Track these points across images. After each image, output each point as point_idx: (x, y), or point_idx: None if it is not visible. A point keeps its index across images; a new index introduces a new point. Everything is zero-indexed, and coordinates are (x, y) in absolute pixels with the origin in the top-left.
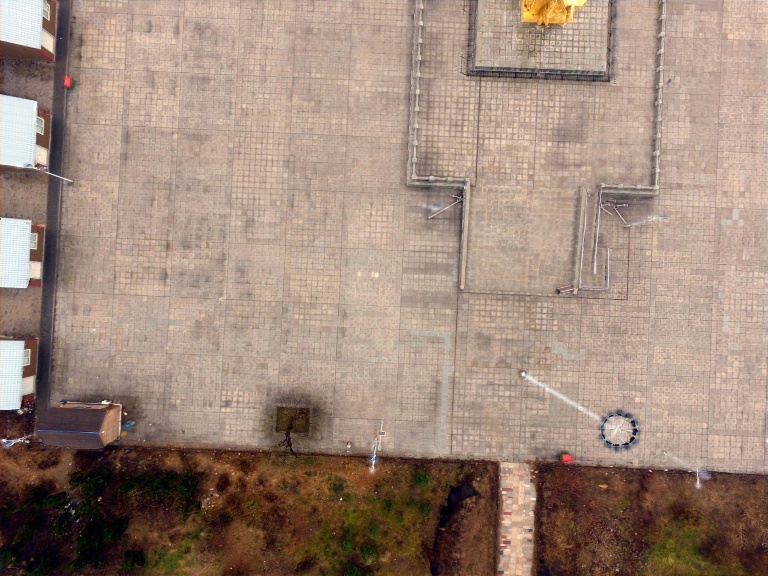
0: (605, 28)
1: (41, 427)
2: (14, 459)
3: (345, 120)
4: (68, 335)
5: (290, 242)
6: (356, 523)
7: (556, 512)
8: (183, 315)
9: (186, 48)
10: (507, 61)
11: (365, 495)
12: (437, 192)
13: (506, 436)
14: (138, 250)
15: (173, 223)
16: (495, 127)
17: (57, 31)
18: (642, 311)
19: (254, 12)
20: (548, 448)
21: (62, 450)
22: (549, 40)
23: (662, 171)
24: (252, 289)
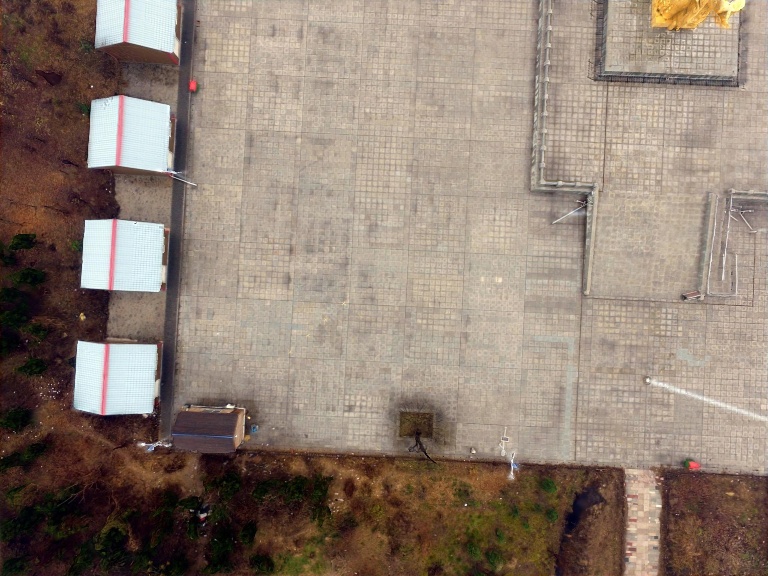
0: (736, 33)
1: (175, 431)
2: (140, 462)
3: (469, 125)
4: (192, 339)
5: (413, 247)
6: (481, 529)
7: (684, 519)
8: (306, 319)
9: (310, 52)
10: (637, 66)
11: (490, 501)
12: (561, 197)
13: (630, 442)
14: (261, 254)
15: (296, 227)
16: (622, 132)
17: (182, 35)
18: (767, 318)
19: (378, 16)
20: (673, 455)
21: (187, 454)
22: (679, 45)
23: None
24: (375, 294)
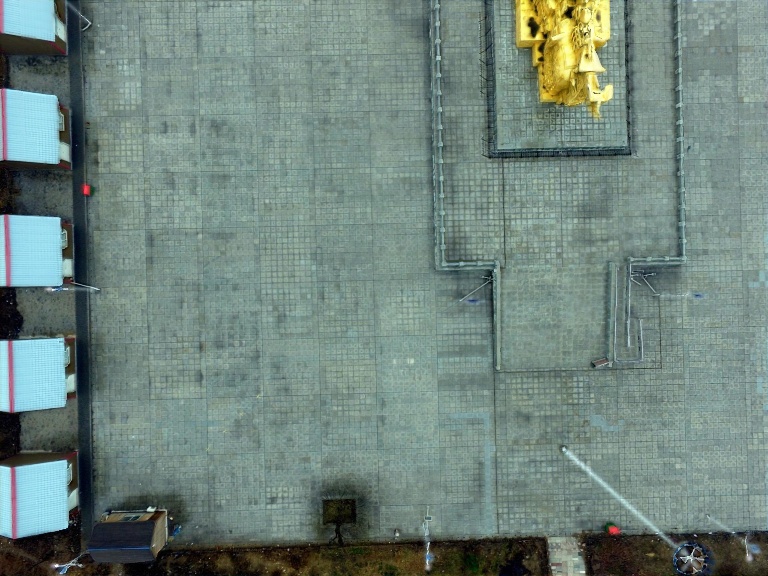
0: (624, 103)
1: (91, 546)
2: (63, 574)
3: (369, 208)
4: (107, 444)
5: (323, 334)
6: None
7: None
8: (221, 415)
9: (204, 147)
10: (529, 142)
11: None
12: (466, 274)
13: (551, 511)
14: (171, 354)
15: (204, 324)
16: (520, 207)
17: (72, 139)
18: (677, 378)
19: (270, 106)
20: (593, 520)
21: None
22: (569, 118)
23: (687, 238)
24: (289, 384)
